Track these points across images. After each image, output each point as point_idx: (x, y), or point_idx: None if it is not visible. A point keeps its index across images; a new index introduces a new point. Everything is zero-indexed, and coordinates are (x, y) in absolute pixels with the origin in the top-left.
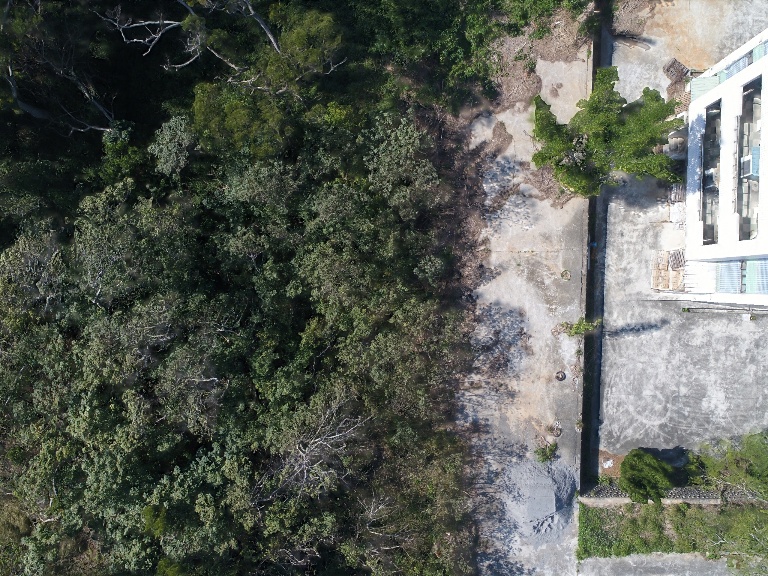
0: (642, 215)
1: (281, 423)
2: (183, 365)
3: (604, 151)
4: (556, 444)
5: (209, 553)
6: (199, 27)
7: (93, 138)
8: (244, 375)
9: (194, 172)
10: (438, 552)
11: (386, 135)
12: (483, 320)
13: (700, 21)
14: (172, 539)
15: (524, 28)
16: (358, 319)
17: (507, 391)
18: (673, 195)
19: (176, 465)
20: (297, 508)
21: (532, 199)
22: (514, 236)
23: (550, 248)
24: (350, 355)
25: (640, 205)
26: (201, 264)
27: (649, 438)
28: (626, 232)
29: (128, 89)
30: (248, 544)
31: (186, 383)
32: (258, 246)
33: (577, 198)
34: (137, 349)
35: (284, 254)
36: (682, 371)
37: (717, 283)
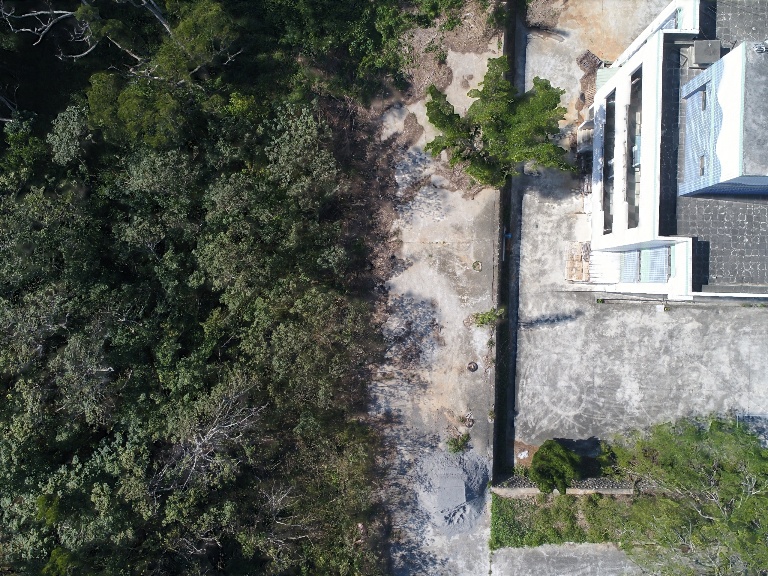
0: (556, 206)
1: (183, 413)
2: (80, 355)
3: (498, 141)
4: (468, 435)
5: (108, 542)
6: (92, 17)
7: (1, 129)
8: (148, 365)
9: (104, 163)
10: (343, 542)
11: (288, 125)
12: (395, 311)
13: (613, 13)
14: (68, 528)
15: (435, 20)
16: (259, 309)
17: (419, 382)
18: (585, 186)
19: (76, 455)
20: (197, 497)
21: (443, 190)
22: (426, 227)
23: (461, 239)
24: (250, 345)
25: (554, 196)
26: (109, 255)
27: (564, 429)
28: (541, 223)
29: (37, 80)
30: (152, 534)
31: (88, 373)
32: (154, 236)
33: (488, 189)
34: (32, 339)
35: (191, 245)
36: (596, 362)
37: (621, 273)
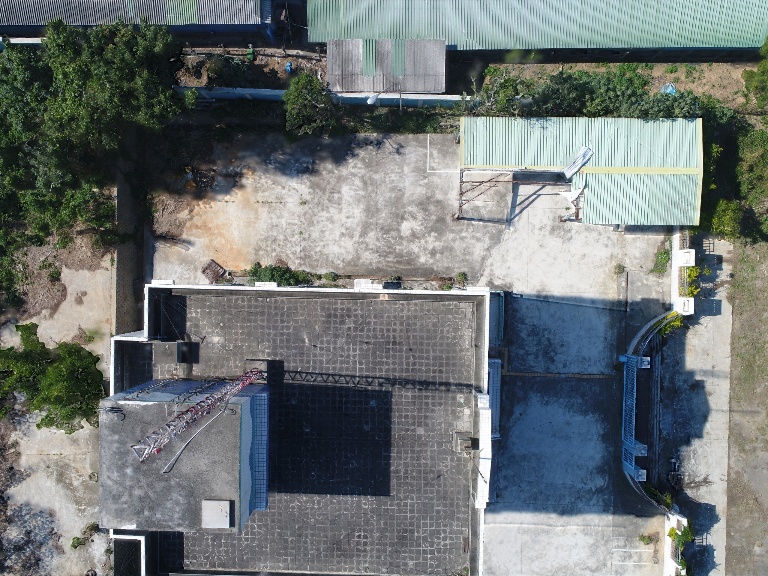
0: None
1: None
2: None
3: None
4: None
5: None
6: None
7: None
8: None
9: None
10: None
11: None
12: (14, 520)
13: (236, 223)
14: None
15: (49, 237)
16: None
17: None
18: None
19: None
20: None
21: None
22: (43, 439)
23: (78, 451)
24: None
25: None
26: None
27: None
28: None
29: None
30: None
31: None
32: None
33: None
34: None
35: None
36: None
37: None
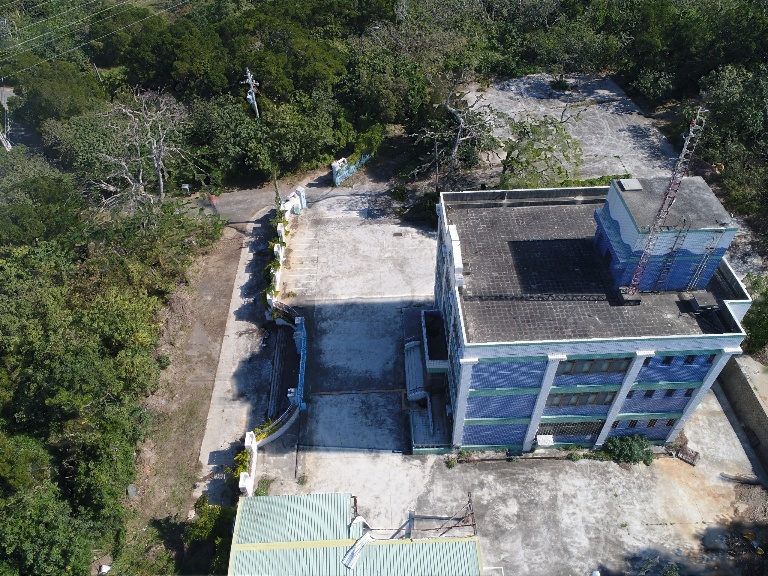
0: None
1: None
2: None
3: None
4: None
5: None
6: None
7: None
8: None
9: None
10: None
11: None
12: (760, 268)
13: (684, 502)
14: None
15: None
16: None
17: None
18: None
19: None
20: None
21: None
22: None
23: None
24: None
25: None
26: None
27: None
28: None
29: None
30: None
31: None
32: None
33: None
34: None
35: None
36: None
37: None
